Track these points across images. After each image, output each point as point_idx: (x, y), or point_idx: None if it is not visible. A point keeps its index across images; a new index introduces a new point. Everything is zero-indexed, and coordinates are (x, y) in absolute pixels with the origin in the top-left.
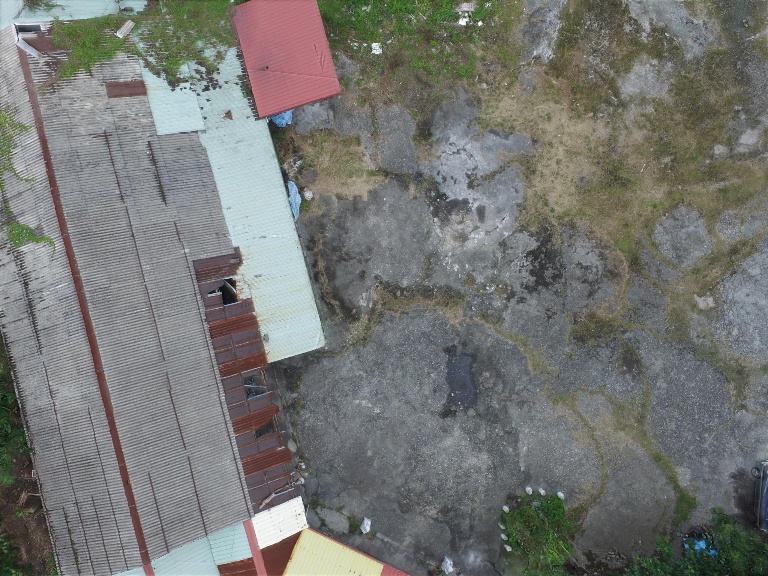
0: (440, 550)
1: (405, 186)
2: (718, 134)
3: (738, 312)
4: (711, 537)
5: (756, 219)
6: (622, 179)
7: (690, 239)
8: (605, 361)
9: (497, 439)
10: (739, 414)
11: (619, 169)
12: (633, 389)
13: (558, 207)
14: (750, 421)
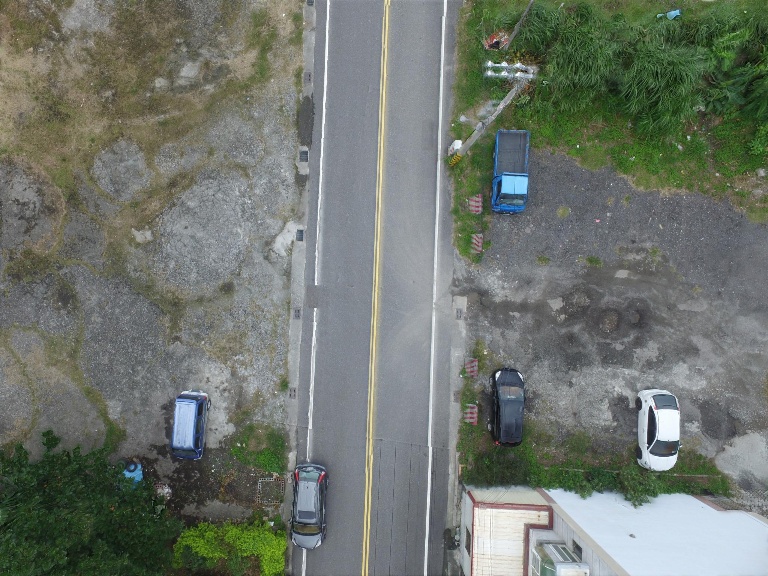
0: None
1: None
2: (159, 67)
3: (176, 245)
4: (141, 468)
5: (196, 152)
6: (61, 114)
7: (129, 173)
8: (39, 297)
9: None
10: (173, 346)
11: (58, 104)
12: (67, 324)
13: None
14: (184, 352)
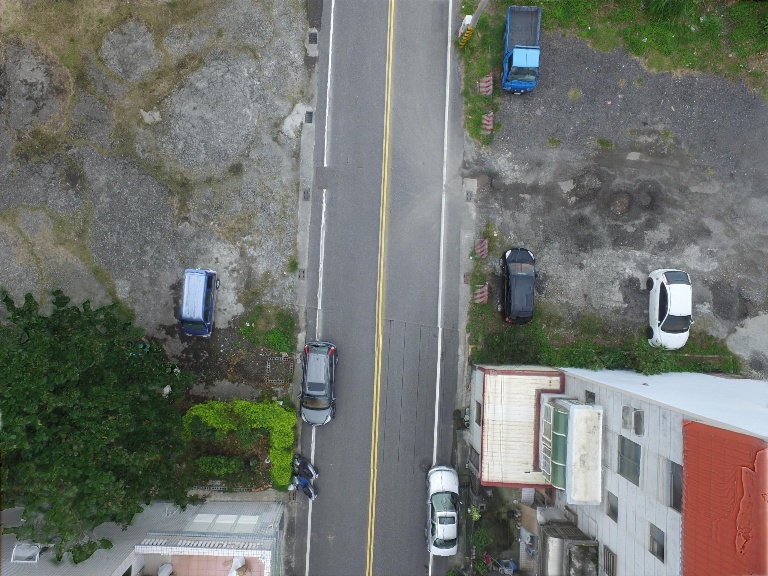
0: None
1: None
2: None
3: (184, 126)
4: None
5: (205, 33)
6: None
7: (137, 54)
8: (48, 177)
9: None
10: (182, 226)
11: None
12: (75, 204)
13: (1, 23)
14: (193, 233)
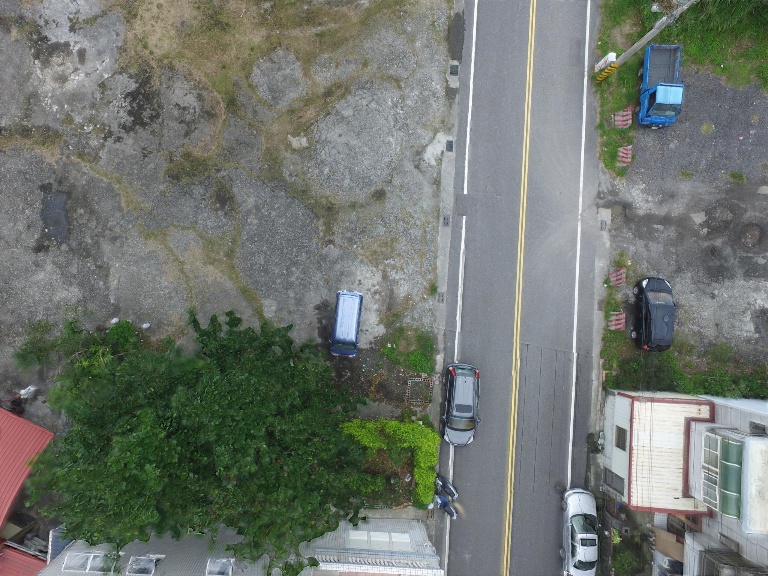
0: (27, 379)
1: (7, 29)
2: None
3: (330, 152)
4: None
5: (351, 63)
6: (221, 24)
7: (286, 82)
8: (198, 198)
9: (88, 273)
10: (326, 249)
11: (219, 14)
12: (224, 225)
13: (157, 50)
14: (337, 255)
